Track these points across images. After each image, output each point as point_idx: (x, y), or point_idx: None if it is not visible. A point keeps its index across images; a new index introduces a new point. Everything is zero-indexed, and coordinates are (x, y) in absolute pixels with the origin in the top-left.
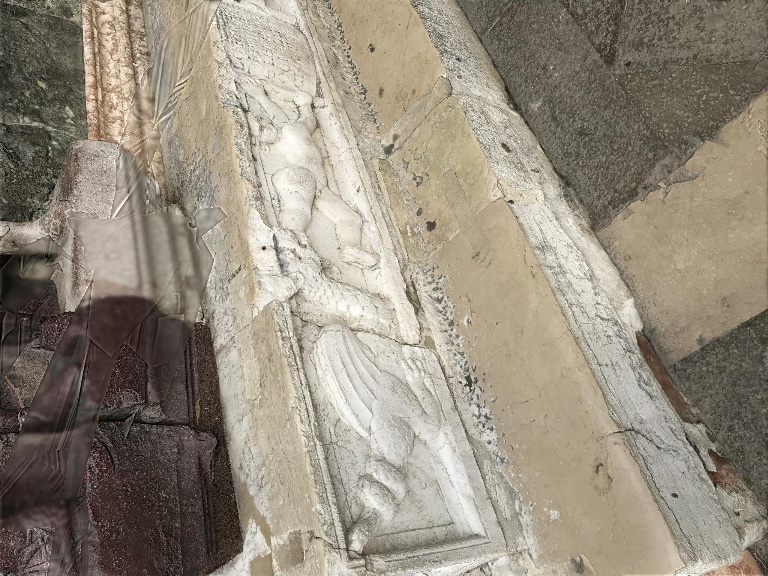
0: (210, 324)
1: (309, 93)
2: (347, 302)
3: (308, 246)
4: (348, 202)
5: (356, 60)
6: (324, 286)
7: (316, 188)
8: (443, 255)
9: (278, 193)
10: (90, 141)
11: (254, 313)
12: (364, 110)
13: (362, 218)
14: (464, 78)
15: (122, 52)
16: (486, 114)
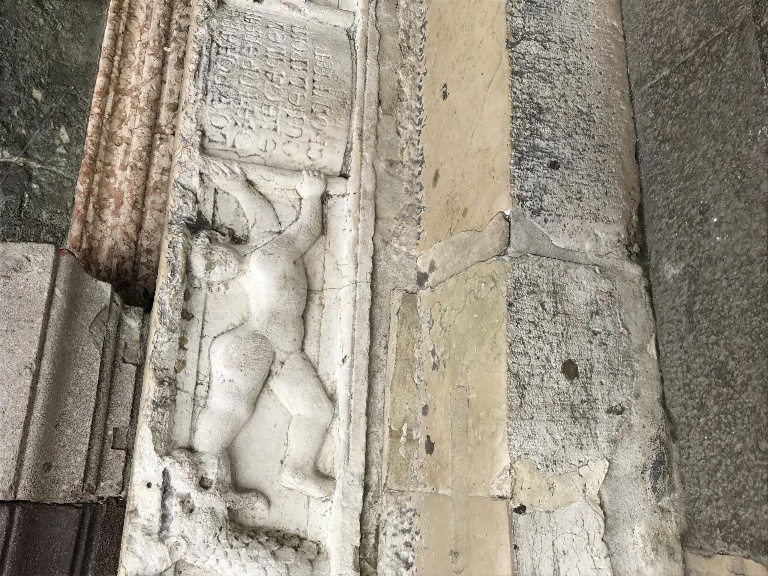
0: (126, 503)
1: (322, 177)
2: (249, 575)
3: (213, 486)
4: (325, 376)
5: (426, 100)
6: (217, 555)
7: (274, 362)
8: (427, 506)
9: (211, 373)
10: (15, 244)
11: (120, 573)
12: (410, 197)
13: (335, 410)
14: (547, 212)
15: (154, 30)
16: (561, 292)
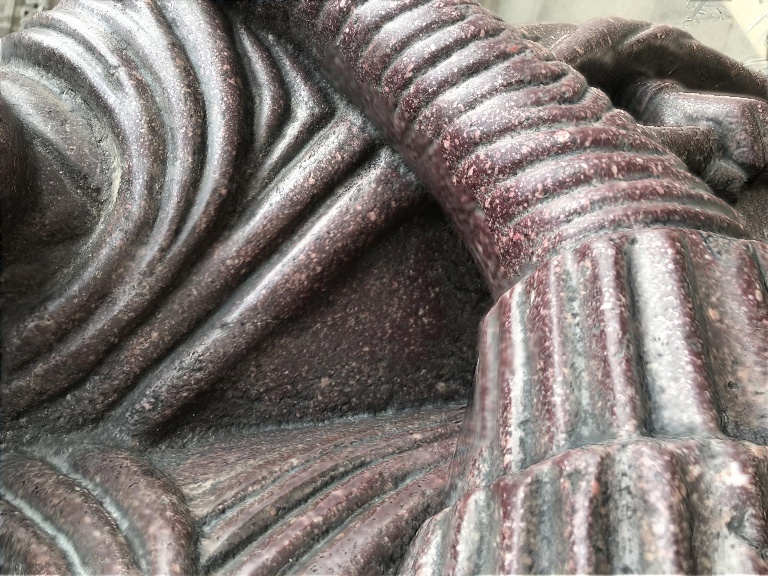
0: None
1: None
2: None
3: None
4: None
5: None
6: None
7: None
8: None
9: None
10: None
11: None
12: None
13: None
14: None
15: None
16: None
